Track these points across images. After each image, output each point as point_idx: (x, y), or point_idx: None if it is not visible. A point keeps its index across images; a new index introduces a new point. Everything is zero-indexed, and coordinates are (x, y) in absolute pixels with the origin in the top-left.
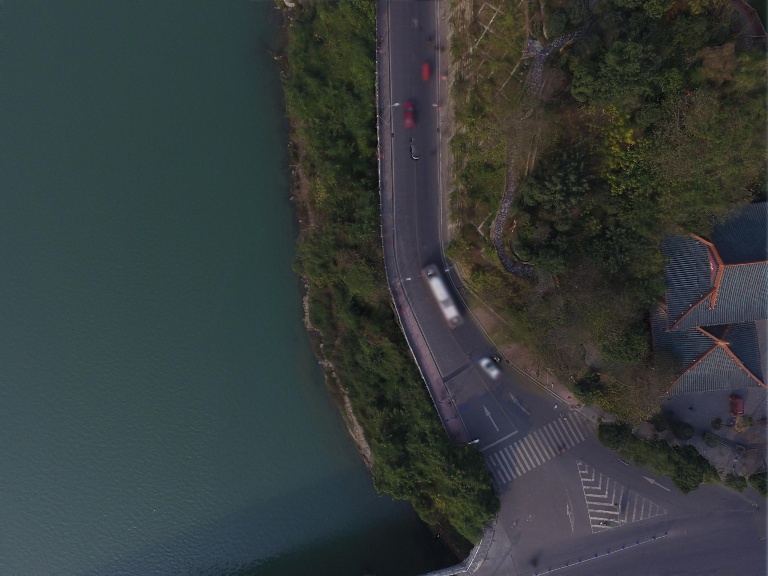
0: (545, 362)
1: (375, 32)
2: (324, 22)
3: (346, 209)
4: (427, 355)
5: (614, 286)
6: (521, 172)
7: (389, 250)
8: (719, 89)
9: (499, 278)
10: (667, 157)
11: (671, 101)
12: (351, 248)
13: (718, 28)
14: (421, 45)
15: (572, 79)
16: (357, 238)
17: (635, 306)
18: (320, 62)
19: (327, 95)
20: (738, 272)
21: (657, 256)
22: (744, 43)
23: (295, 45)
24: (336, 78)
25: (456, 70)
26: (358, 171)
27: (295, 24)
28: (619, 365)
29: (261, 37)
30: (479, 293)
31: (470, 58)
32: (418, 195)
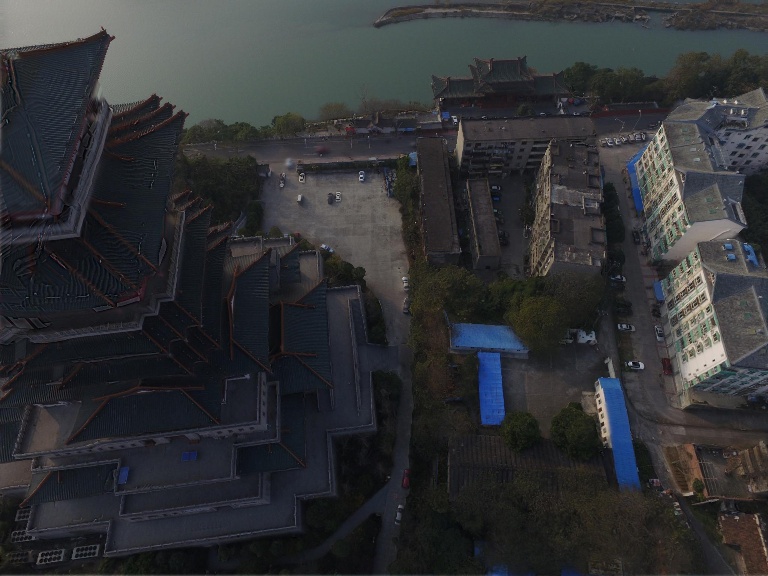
0: None
1: (185, 144)
2: None
3: None
4: None
5: None
6: None
7: None
8: None
9: None
10: None
11: None
12: None
13: None
14: None
15: None
16: None
17: None
18: None
19: None
20: None
21: None
22: None
23: None
24: None
25: None
26: None
27: None
28: None
29: None
30: None
31: None
32: None
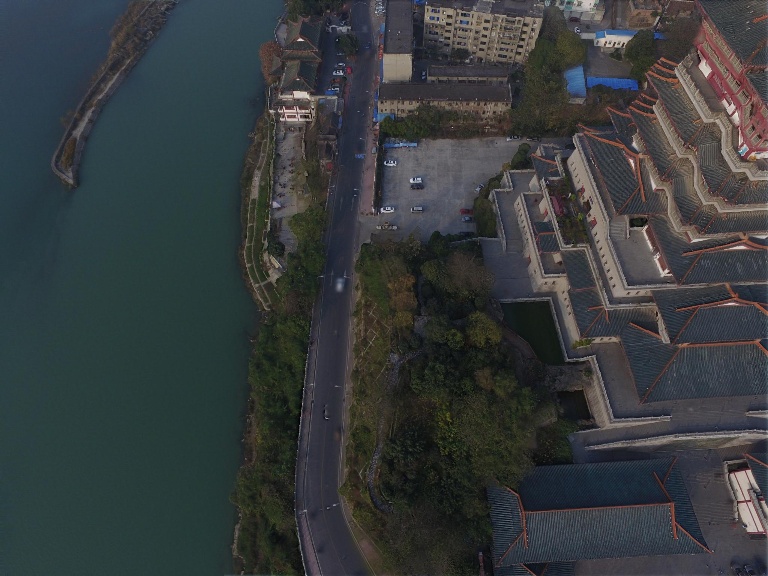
0: None
1: (309, 337)
2: (279, 328)
3: (274, 452)
4: None
5: (450, 524)
6: (387, 434)
7: (300, 487)
8: (490, 393)
9: (369, 513)
10: (469, 432)
11: (469, 397)
12: (271, 483)
13: (493, 356)
14: (338, 346)
15: (411, 379)
16: (277, 476)
17: (468, 543)
18: (274, 351)
19: (274, 372)
20: (538, 518)
21: (476, 502)
22: (515, 364)
23: (261, 338)
24: (282, 361)
25: (355, 364)
26: (288, 425)
27: (263, 327)
28: None
29: (245, 327)
30: (363, 527)
31: (361, 358)
32: (326, 445)
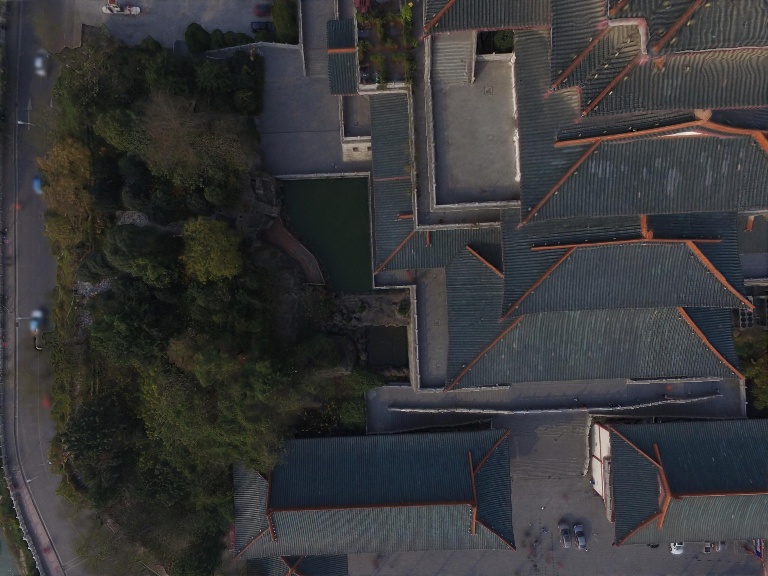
0: (156, 560)
1: None
2: None
3: None
4: (46, 543)
5: (170, 518)
6: None
7: (10, 438)
8: None
9: (68, 498)
10: None
11: None
12: None
13: None
14: None
15: None
16: None
17: (197, 536)
18: None
19: None
20: (288, 514)
21: (201, 497)
22: (273, 304)
23: None
24: None
25: None
26: None
27: None
28: (225, 570)
29: None
30: None
31: None
32: (40, 385)
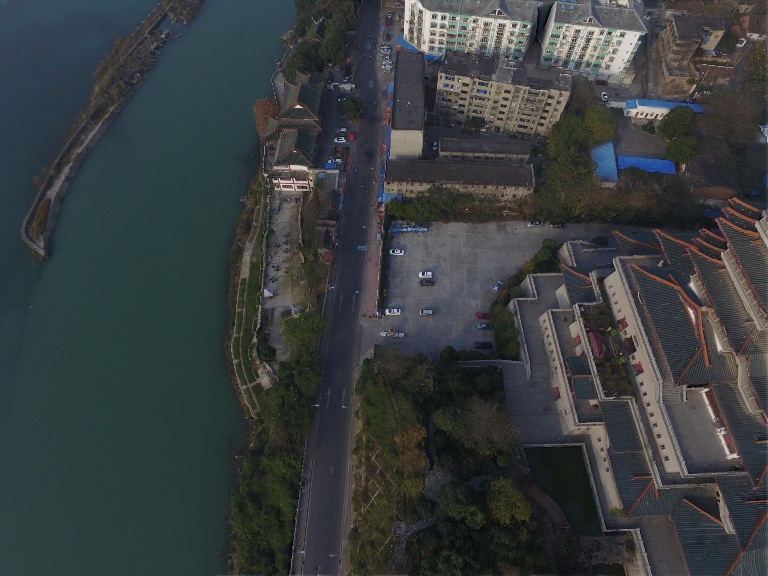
0: None
1: (301, 477)
2: None
3: None
4: None
5: None
6: None
7: None
8: None
9: None
10: None
11: None
12: None
13: (520, 539)
14: (334, 488)
15: (421, 566)
16: None
17: None
18: (260, 488)
19: (260, 518)
20: None
21: None
22: (545, 543)
23: (246, 469)
24: (269, 504)
25: (354, 518)
26: None
27: (248, 454)
28: None
29: (229, 438)
30: None
31: (361, 517)
32: None
